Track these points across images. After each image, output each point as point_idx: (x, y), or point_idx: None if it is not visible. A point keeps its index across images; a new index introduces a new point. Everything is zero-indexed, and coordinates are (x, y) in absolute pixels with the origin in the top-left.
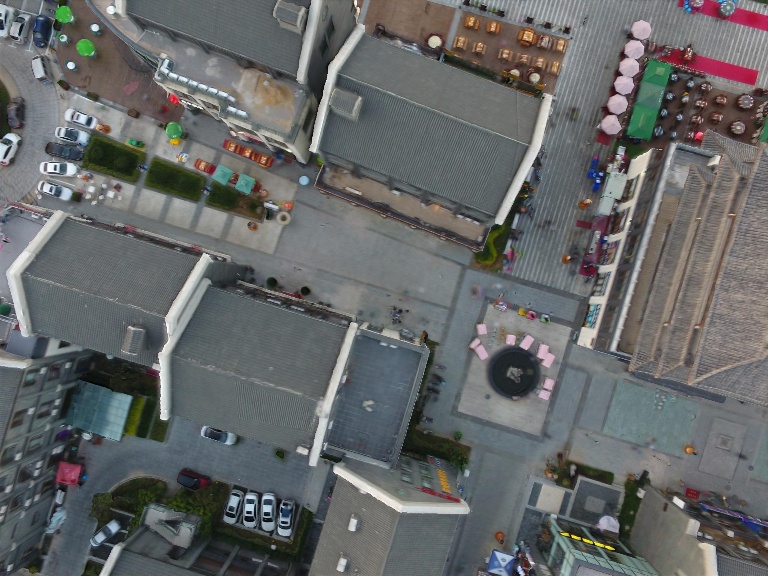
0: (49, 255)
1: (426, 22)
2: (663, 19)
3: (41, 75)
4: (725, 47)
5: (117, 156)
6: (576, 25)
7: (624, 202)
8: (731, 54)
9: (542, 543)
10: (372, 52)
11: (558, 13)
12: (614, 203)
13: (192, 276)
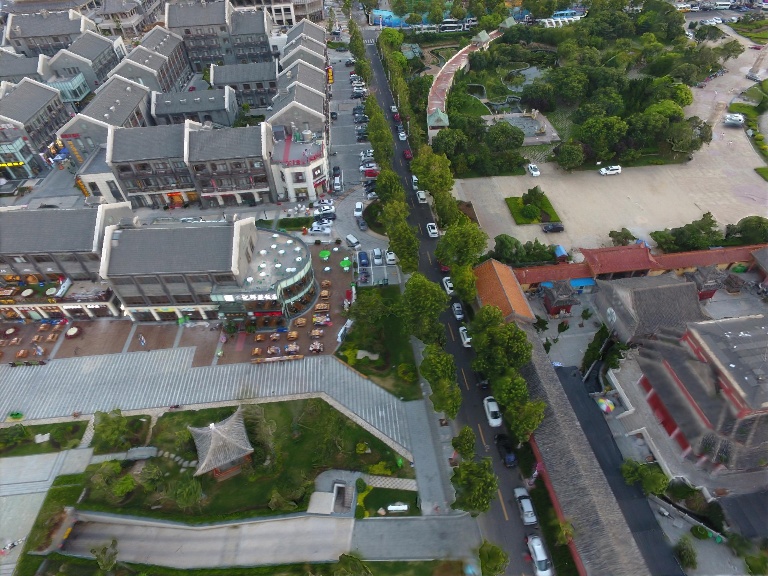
0: (257, 137)
1: (79, 344)
2: None
3: (348, 236)
4: None
5: (291, 223)
6: None
7: None
8: None
9: (37, 166)
10: (86, 237)
11: None
12: None
13: (186, 149)
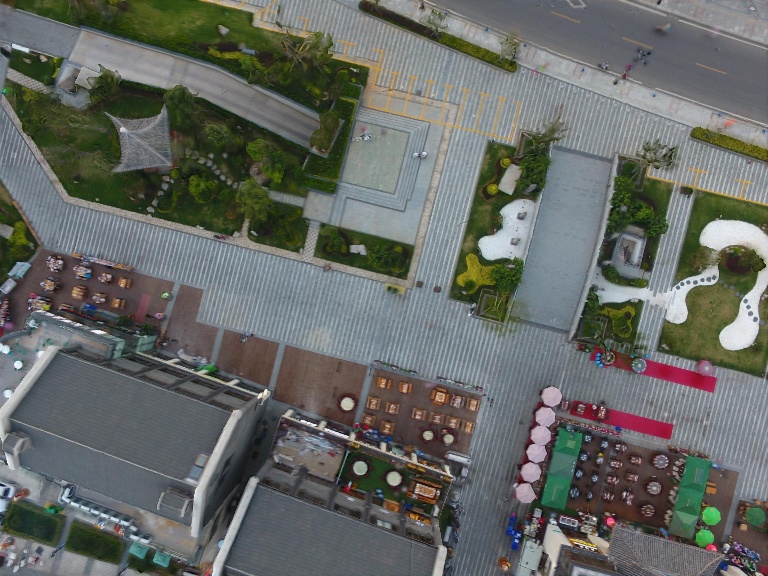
0: None
1: (339, 380)
2: (576, 373)
3: None
4: (639, 401)
5: (36, 524)
6: (489, 381)
7: (541, 572)
8: (645, 408)
9: None
10: (264, 515)
11: (470, 369)
12: (531, 573)
13: None
